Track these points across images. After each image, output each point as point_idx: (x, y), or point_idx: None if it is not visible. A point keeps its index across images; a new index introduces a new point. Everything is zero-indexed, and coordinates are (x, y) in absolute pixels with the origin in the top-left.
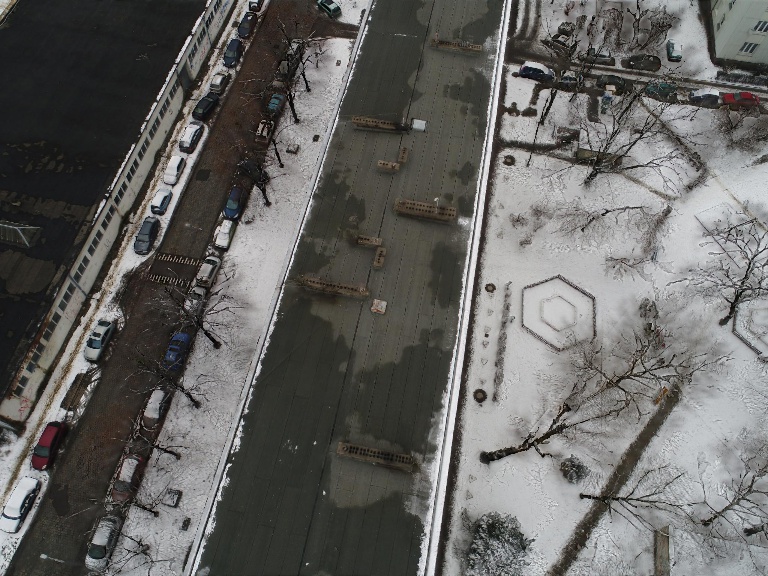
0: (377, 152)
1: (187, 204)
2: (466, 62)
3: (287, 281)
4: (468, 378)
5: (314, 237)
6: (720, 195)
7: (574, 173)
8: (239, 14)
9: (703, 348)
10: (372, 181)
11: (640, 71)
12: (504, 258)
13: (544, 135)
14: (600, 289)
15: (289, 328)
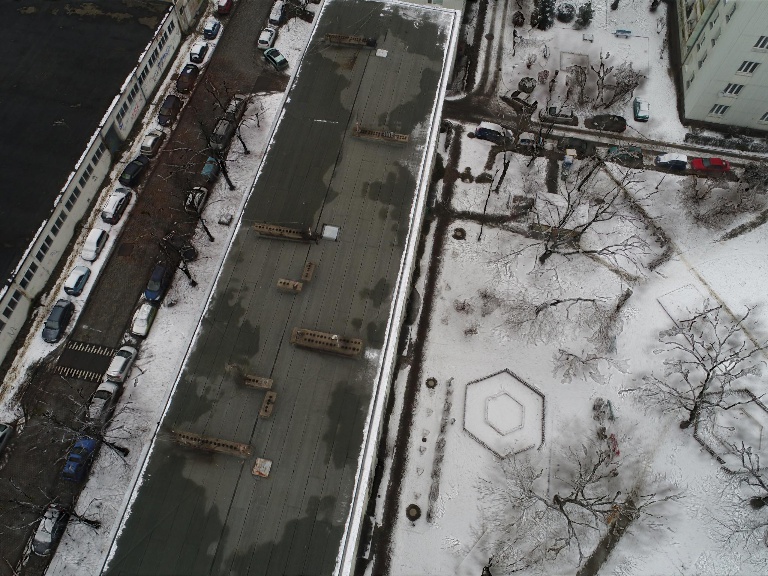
0: (280, 266)
1: (106, 283)
2: (391, 154)
3: (159, 433)
4: (401, 491)
5: (197, 375)
6: (685, 275)
7: (529, 249)
8: (179, 65)
9: (661, 456)
10: (271, 303)
11: (604, 132)
12: (448, 348)
13: (498, 205)
14: (551, 385)
15: (155, 495)
